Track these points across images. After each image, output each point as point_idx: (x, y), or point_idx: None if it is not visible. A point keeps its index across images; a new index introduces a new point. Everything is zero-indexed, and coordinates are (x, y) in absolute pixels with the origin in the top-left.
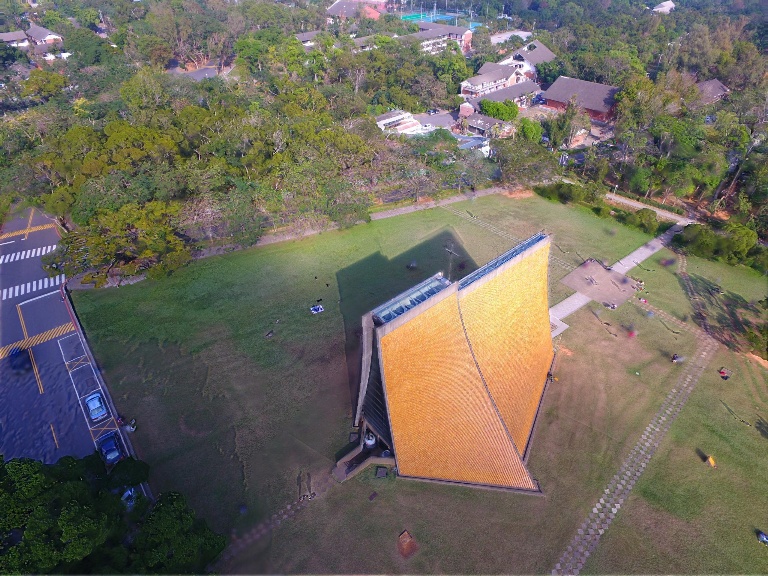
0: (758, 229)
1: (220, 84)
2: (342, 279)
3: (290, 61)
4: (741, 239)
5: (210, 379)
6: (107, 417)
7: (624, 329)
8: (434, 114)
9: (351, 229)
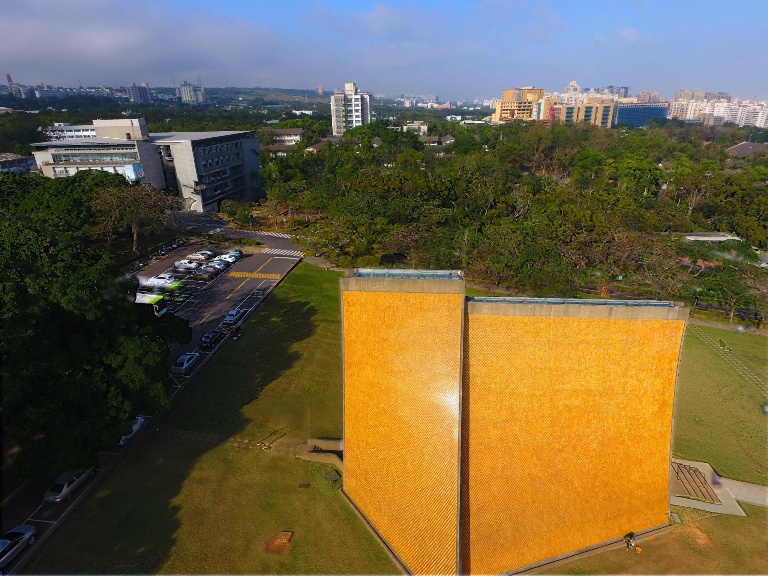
0: None
1: (538, 179)
2: None
3: (624, 173)
4: None
5: (308, 340)
6: (232, 324)
7: None
8: None
9: None
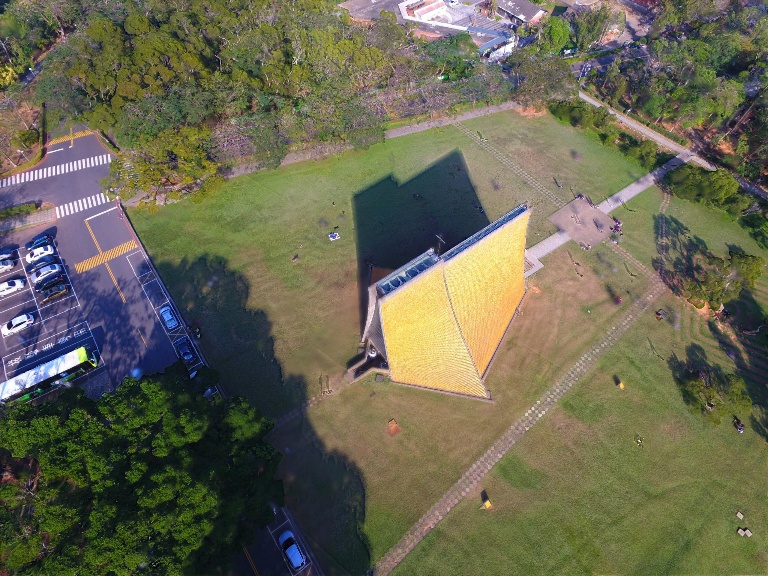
0: (746, 173)
1: None
2: (356, 206)
3: None
4: (722, 188)
5: (251, 297)
6: (178, 326)
7: (591, 270)
8: None
9: None
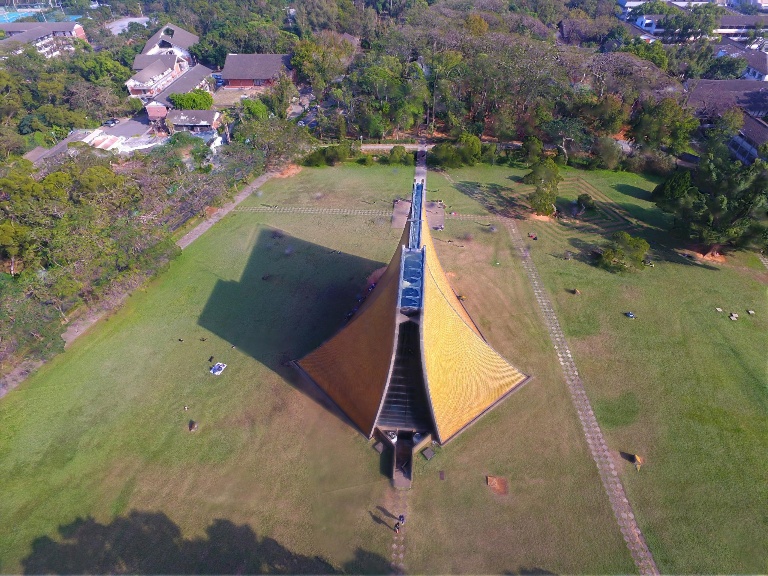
0: None
1: None
2: (212, 325)
3: None
4: (474, 144)
5: (177, 518)
6: None
7: (462, 239)
8: (115, 125)
9: (163, 274)
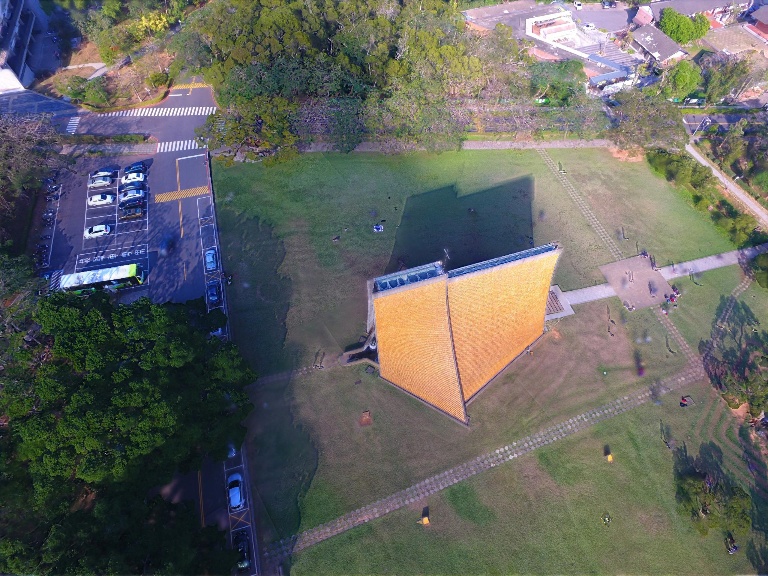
0: None
1: None
2: (409, 206)
3: None
4: None
5: (285, 262)
6: (216, 269)
7: (625, 332)
8: (608, 8)
9: (440, 154)
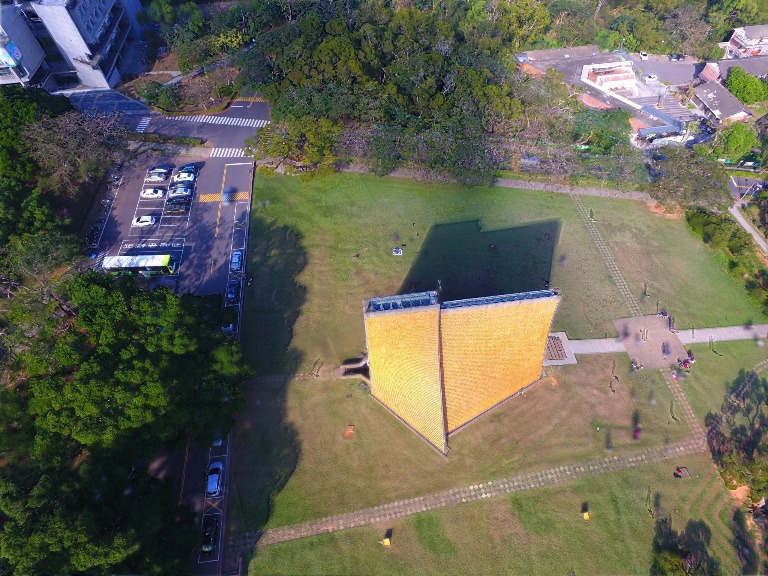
0: None
1: None
2: (432, 234)
3: None
4: None
5: (303, 272)
6: (239, 270)
7: (628, 390)
8: (676, 61)
9: (471, 188)
